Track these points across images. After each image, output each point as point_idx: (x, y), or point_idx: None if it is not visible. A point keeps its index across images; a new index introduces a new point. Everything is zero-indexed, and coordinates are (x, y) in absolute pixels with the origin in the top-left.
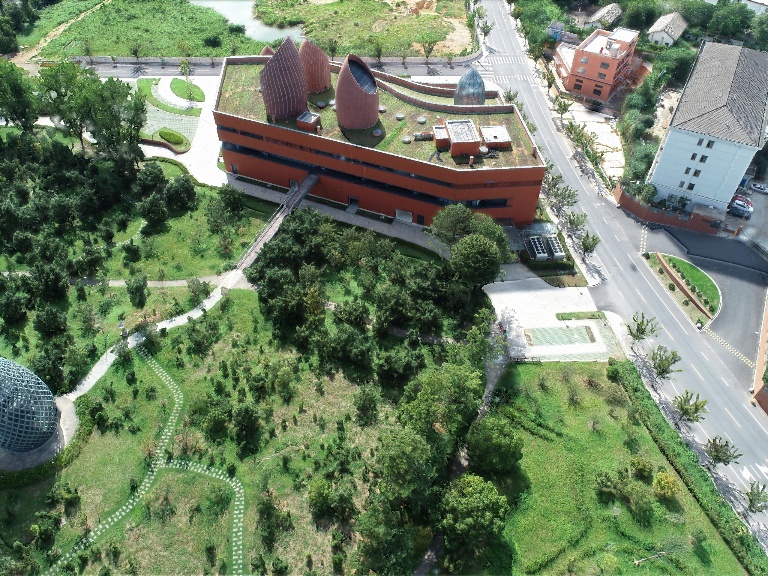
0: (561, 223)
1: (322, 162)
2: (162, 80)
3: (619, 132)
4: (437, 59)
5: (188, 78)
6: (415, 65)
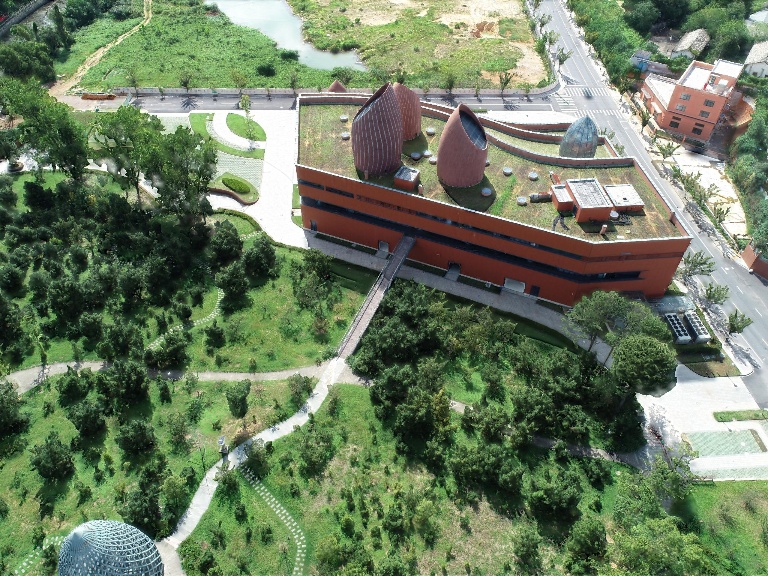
0: (691, 293)
1: (422, 224)
2: (216, 115)
3: (730, 179)
4: (513, 91)
5: (244, 113)
6: (489, 97)
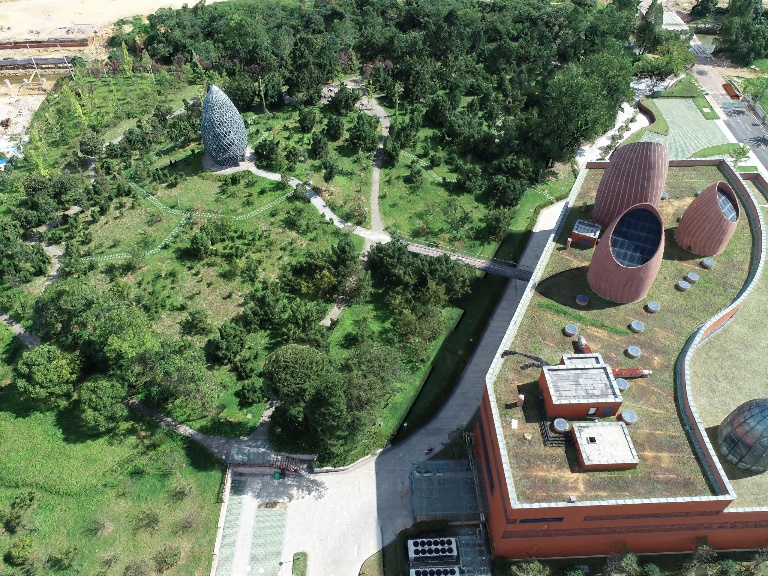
0: None
1: None
2: (746, 159)
3: None
4: None
5: None
6: None
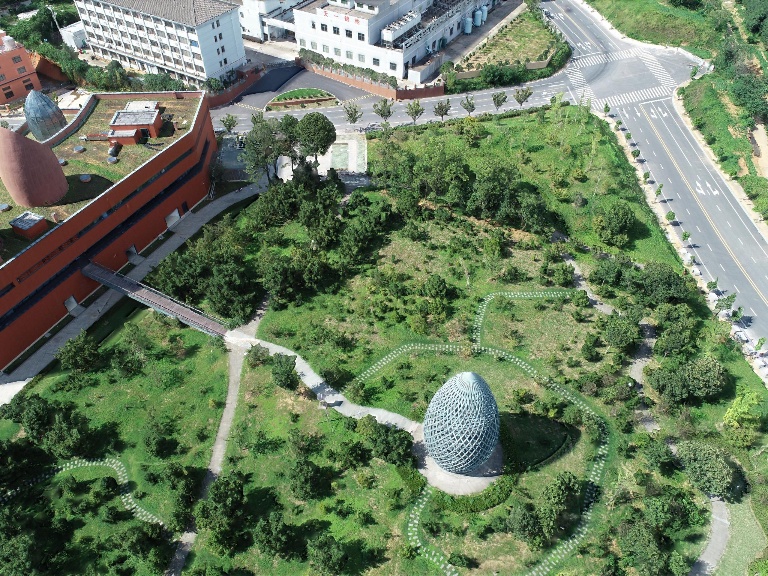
0: None
1: (88, 242)
2: None
3: None
4: None
5: None
6: None
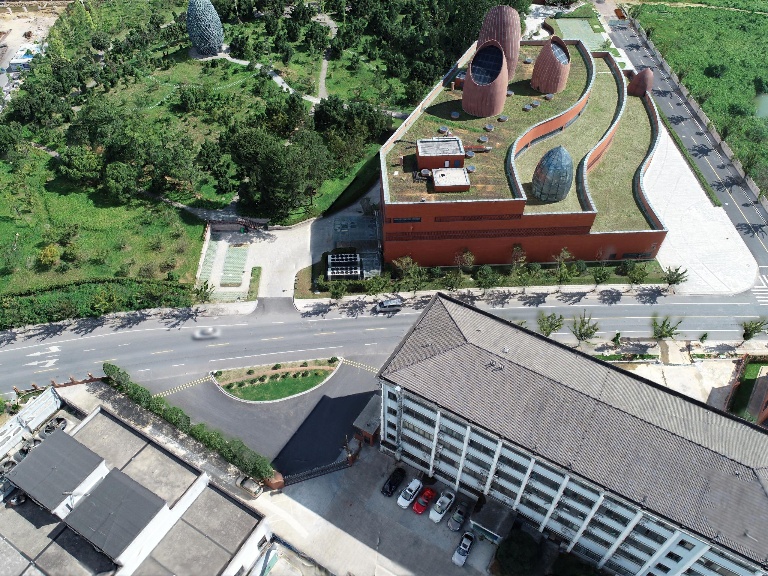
0: None
1: None
2: (618, 58)
3: None
4: None
5: None
6: (760, 213)
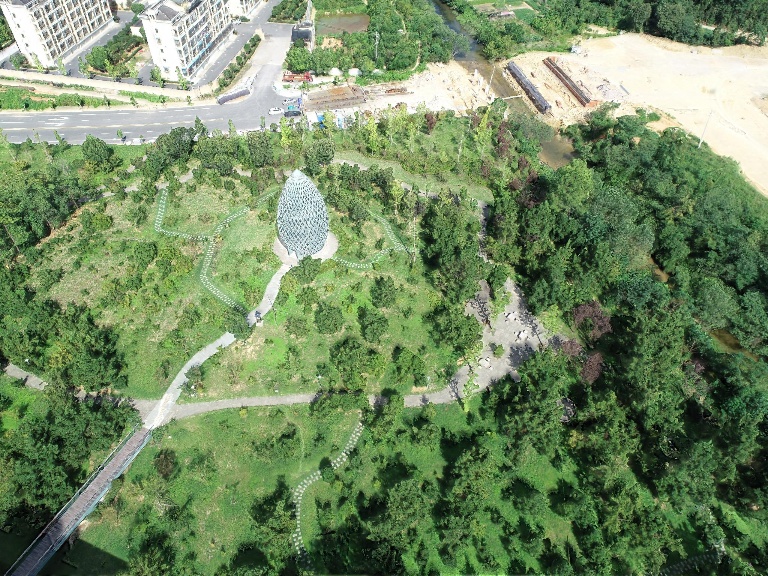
0: None
1: None
2: None
3: None
4: None
5: None
6: None
